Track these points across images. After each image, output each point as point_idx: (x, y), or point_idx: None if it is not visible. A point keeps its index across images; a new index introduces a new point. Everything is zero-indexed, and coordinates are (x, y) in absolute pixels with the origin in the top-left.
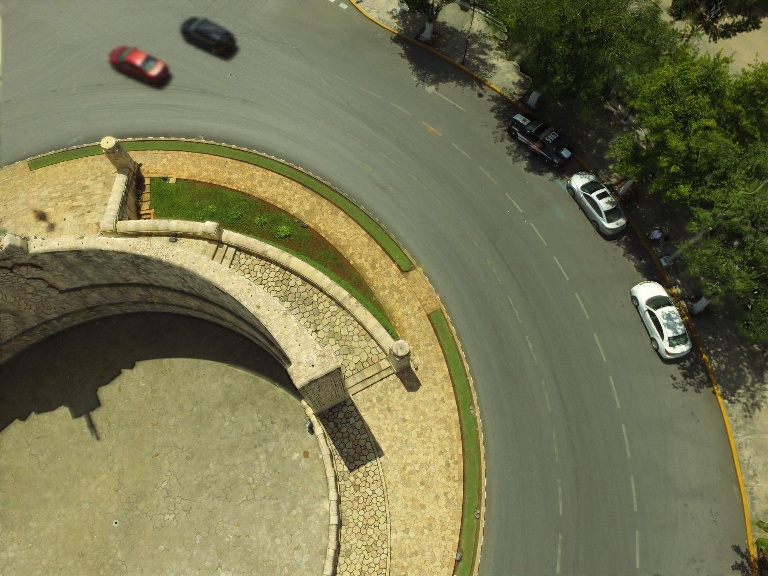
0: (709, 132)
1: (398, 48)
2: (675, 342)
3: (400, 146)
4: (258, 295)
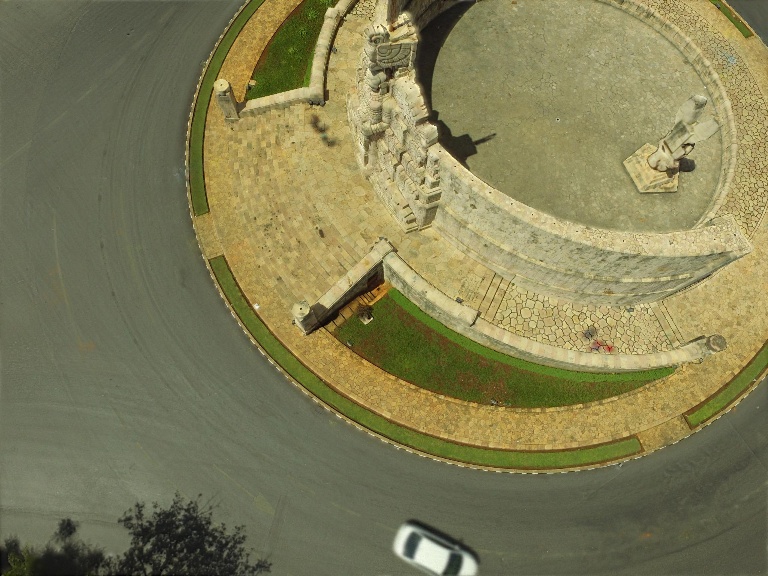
0: None
1: None
2: None
3: None
4: None
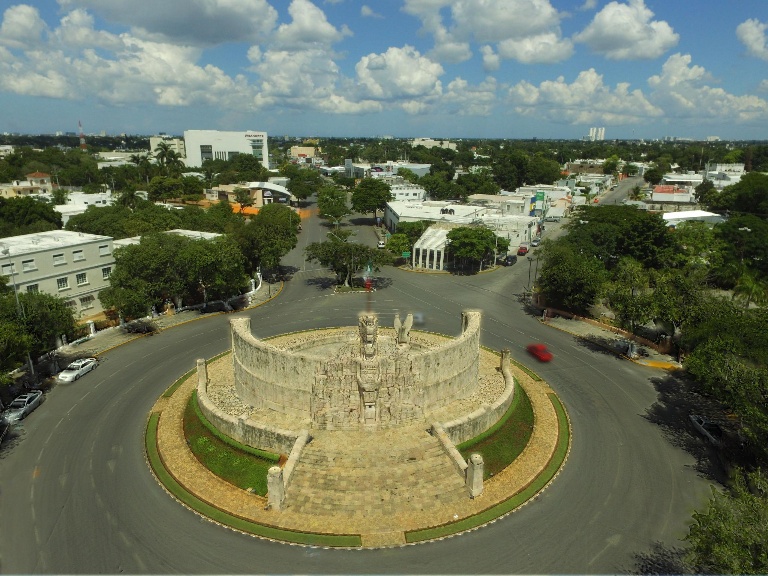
0: None
1: None
2: None
3: (72, 468)
4: (242, 333)
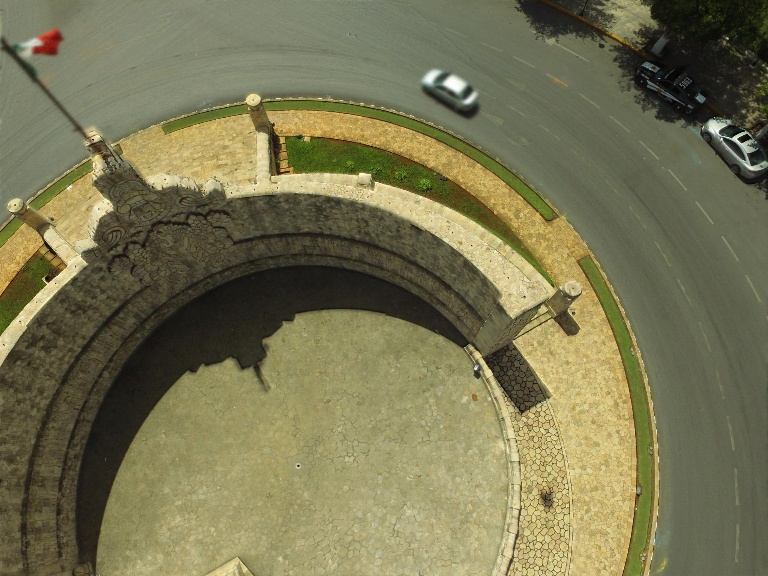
0: None
1: (513, 2)
2: None
3: (528, 98)
4: (459, 232)
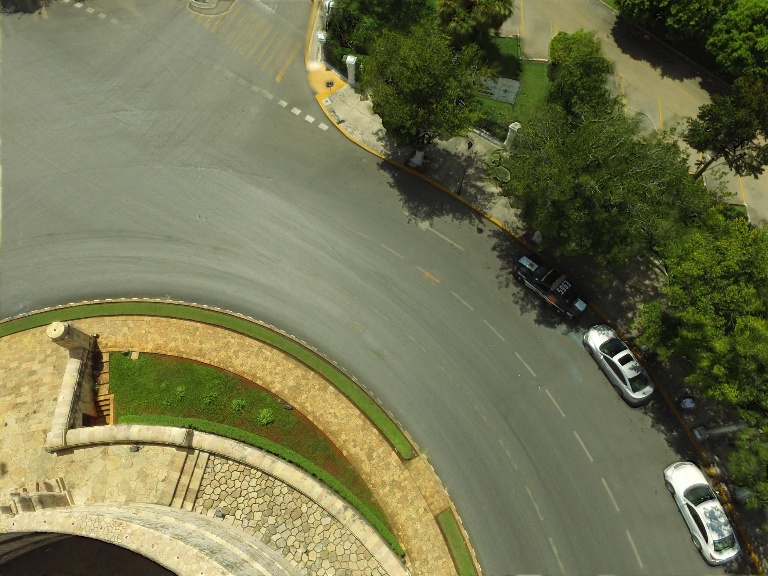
0: (758, 333)
1: (386, 176)
2: (721, 545)
3: (394, 298)
4: None
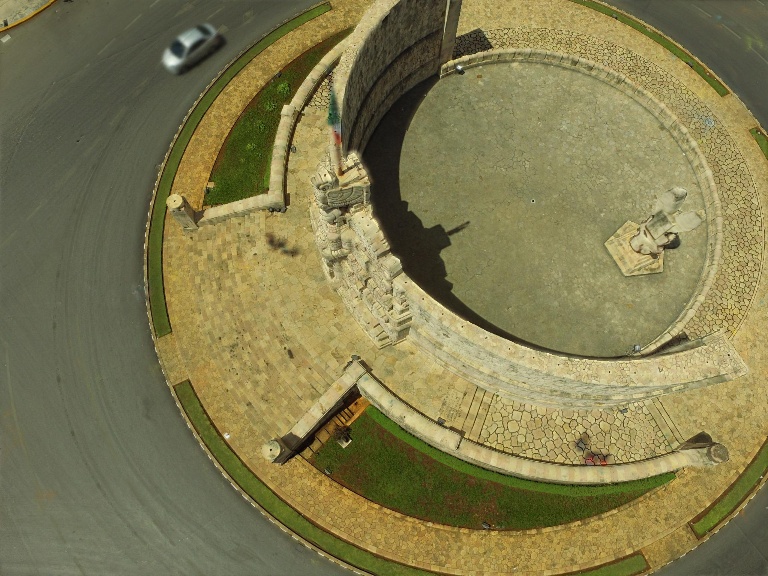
0: None
1: None
2: None
3: (202, 4)
4: None
